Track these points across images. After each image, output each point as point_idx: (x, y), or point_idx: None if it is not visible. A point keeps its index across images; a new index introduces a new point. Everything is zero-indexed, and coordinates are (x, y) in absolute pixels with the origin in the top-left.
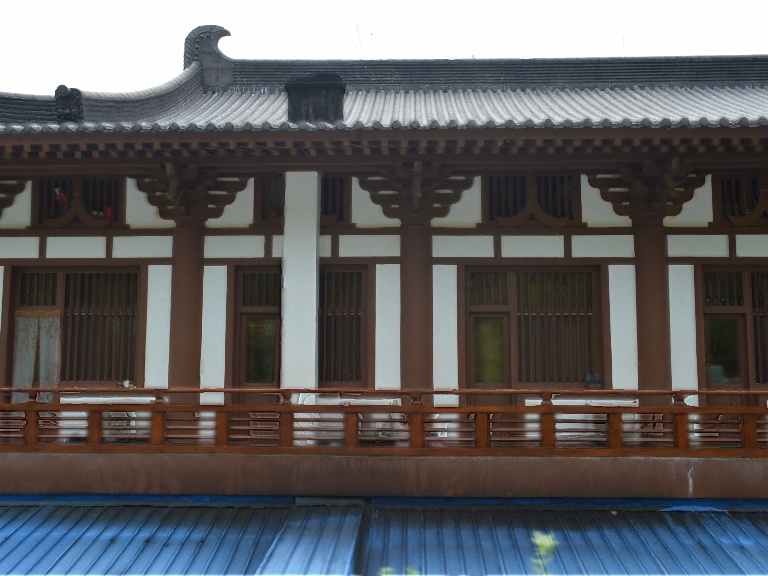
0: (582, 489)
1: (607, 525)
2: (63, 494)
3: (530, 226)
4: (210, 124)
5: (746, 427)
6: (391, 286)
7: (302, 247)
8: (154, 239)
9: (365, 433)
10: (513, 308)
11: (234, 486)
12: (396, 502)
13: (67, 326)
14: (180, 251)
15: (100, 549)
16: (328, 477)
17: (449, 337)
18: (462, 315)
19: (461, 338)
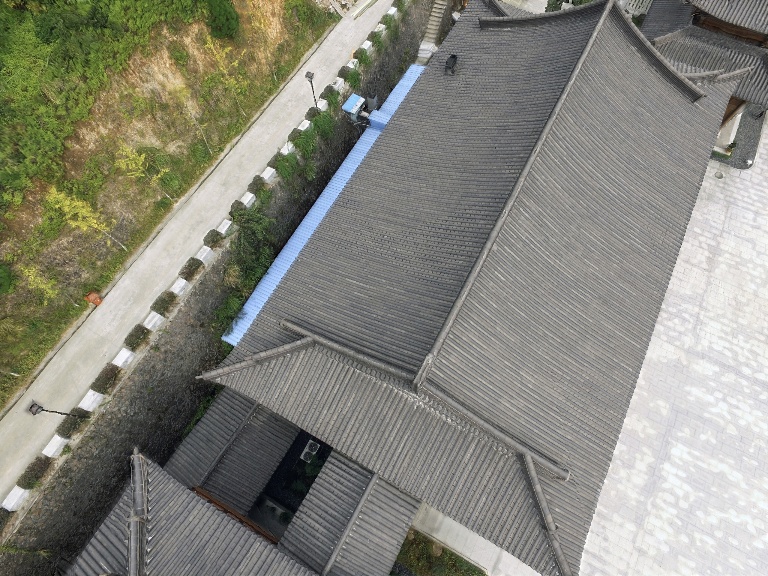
0: None
1: None
2: None
3: None
4: None
5: None
6: None
7: None
8: None
9: None
10: None
11: None
12: None
13: None
14: None
15: None
16: None
17: None
18: None
19: None
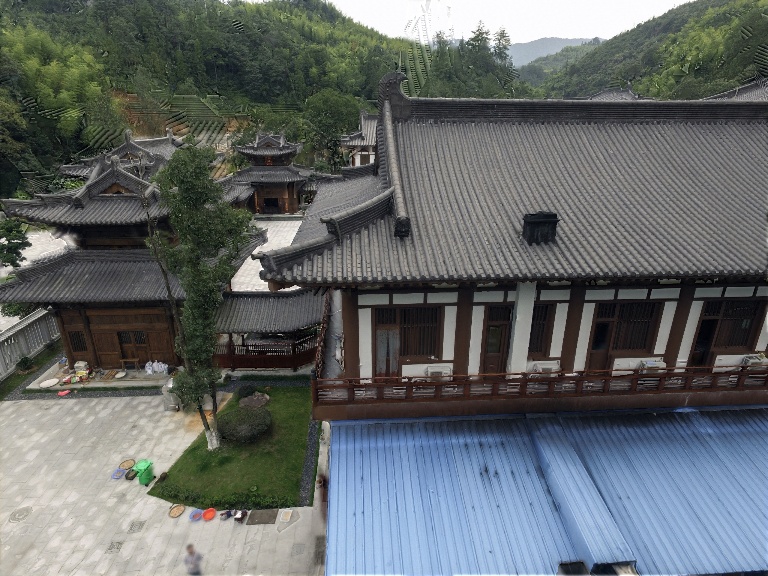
0: (643, 406)
1: (655, 423)
2: (425, 417)
3: (634, 285)
4: (516, 275)
5: (715, 380)
6: (563, 313)
7: (527, 302)
8: (448, 294)
9: (557, 388)
10: (616, 319)
11: (500, 411)
12: (567, 413)
13: (402, 332)
14: (462, 300)
15: (466, 451)
16: (540, 406)
17: (586, 335)
18: (594, 325)
19: (592, 335)
